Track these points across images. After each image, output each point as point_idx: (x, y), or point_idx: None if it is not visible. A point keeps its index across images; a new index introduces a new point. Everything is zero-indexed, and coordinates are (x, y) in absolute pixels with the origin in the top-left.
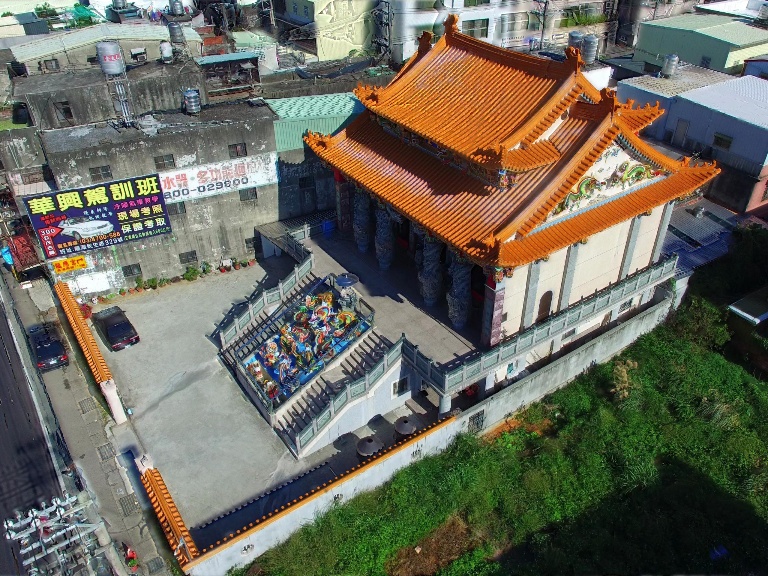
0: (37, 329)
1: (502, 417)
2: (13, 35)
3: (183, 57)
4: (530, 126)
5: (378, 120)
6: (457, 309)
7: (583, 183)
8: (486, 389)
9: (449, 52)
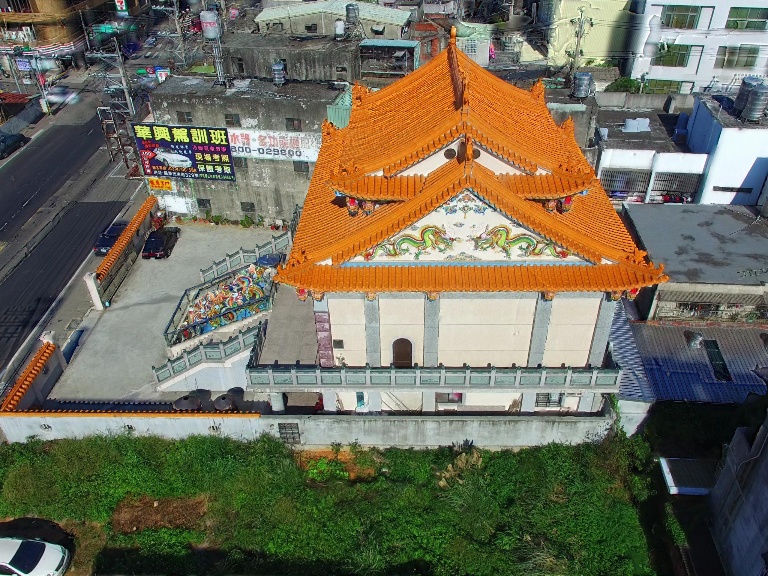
0: (118, 224)
1: (329, 443)
2: None
3: (357, 37)
4: (397, 155)
5: None
6: None
7: (426, 231)
8: (325, 409)
9: (442, 67)
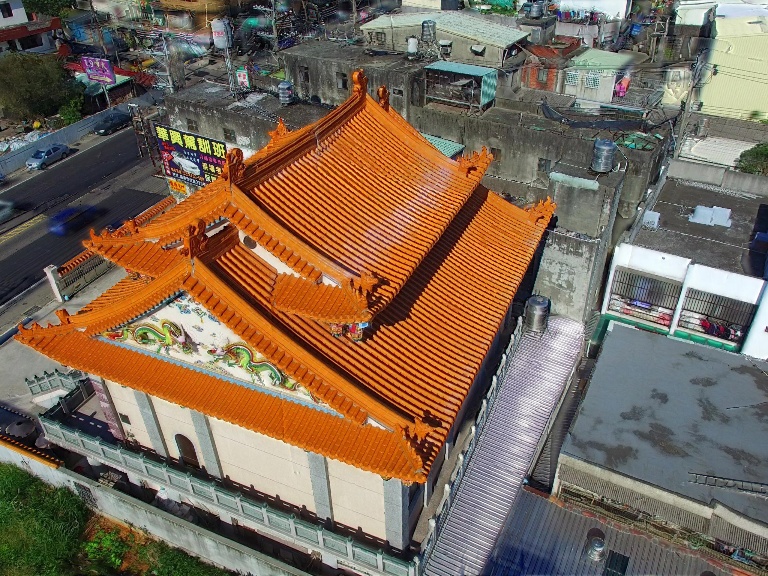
0: None
1: None
2: (432, 7)
3: (433, 57)
4: (173, 225)
5: None
6: None
7: None
8: (130, 480)
9: None
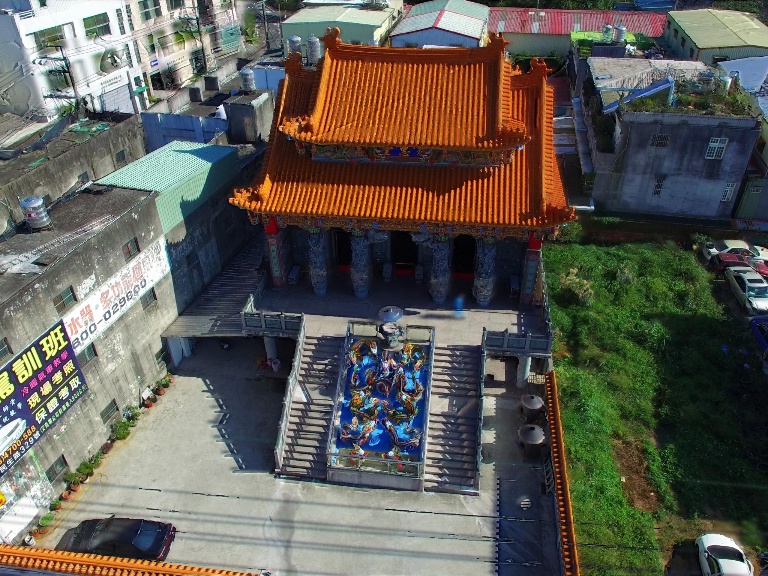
0: None
1: None
2: None
3: None
4: None
5: (314, 151)
6: (491, 287)
7: None
8: None
9: (341, 66)
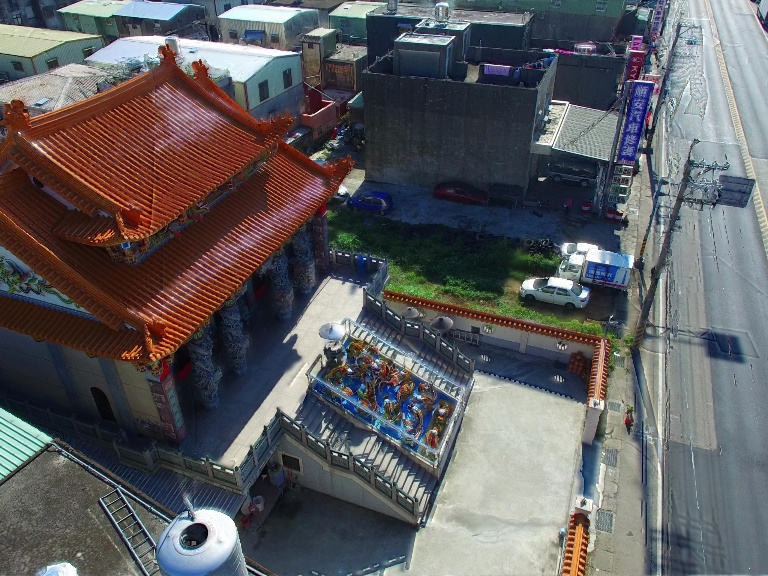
0: None
1: None
2: None
3: None
4: None
5: None
6: None
7: None
8: None
9: (49, 146)
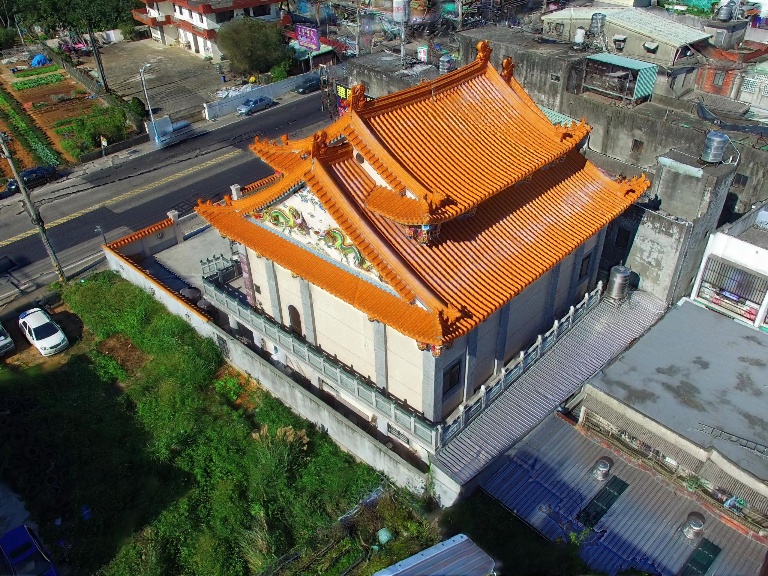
0: None
1: None
2: (625, 4)
3: (598, 48)
4: None
5: None
6: None
7: None
8: None
9: None
